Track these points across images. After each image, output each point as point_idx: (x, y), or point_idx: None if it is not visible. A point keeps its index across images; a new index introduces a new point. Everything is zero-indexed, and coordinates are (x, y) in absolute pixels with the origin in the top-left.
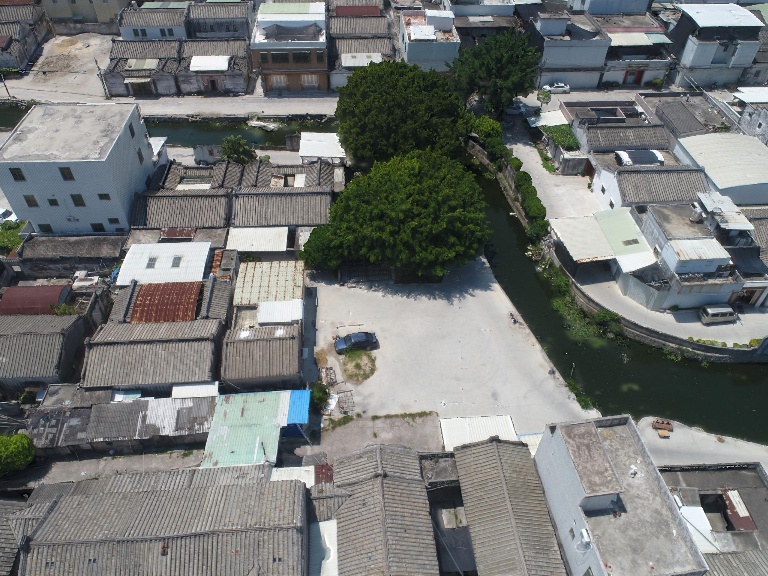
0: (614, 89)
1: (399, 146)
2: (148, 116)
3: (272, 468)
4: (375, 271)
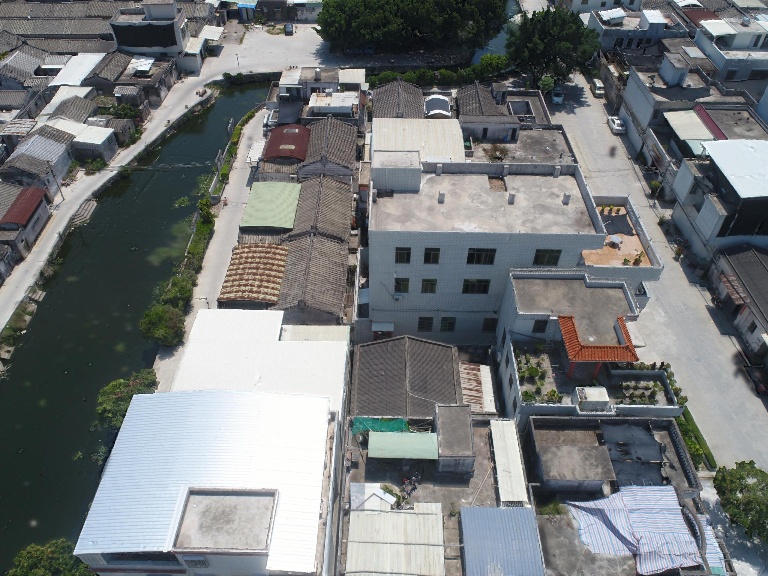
0: (640, 165)
1: None
2: None
3: (220, 1)
4: None
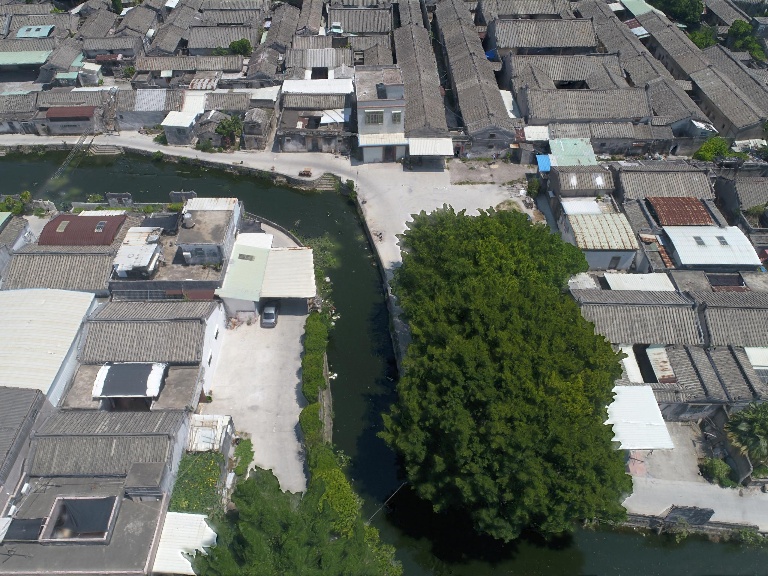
0: None
1: None
2: None
3: None
4: None
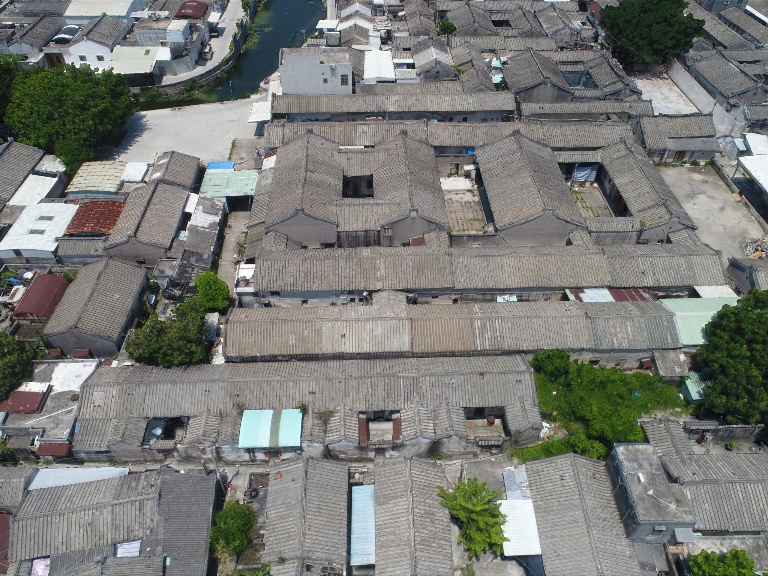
0: None
1: (1, 85)
2: None
3: None
4: (99, 154)
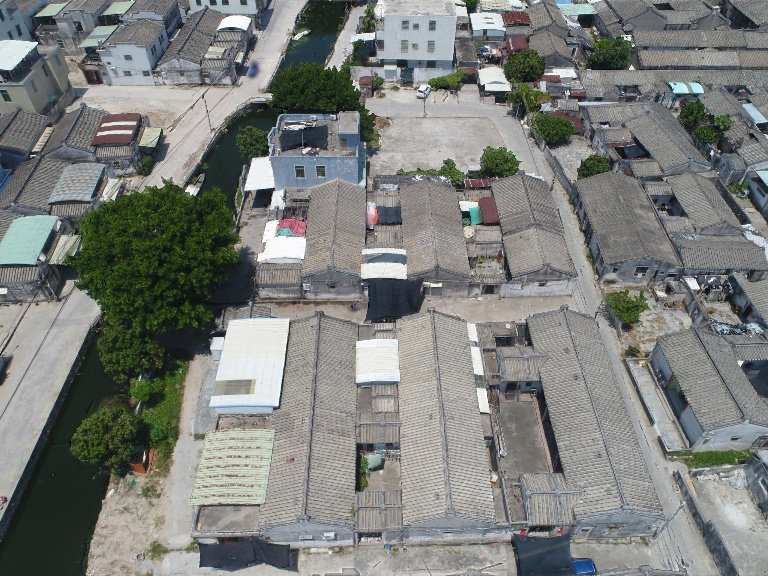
0: None
1: None
2: (276, 69)
3: None
4: None
